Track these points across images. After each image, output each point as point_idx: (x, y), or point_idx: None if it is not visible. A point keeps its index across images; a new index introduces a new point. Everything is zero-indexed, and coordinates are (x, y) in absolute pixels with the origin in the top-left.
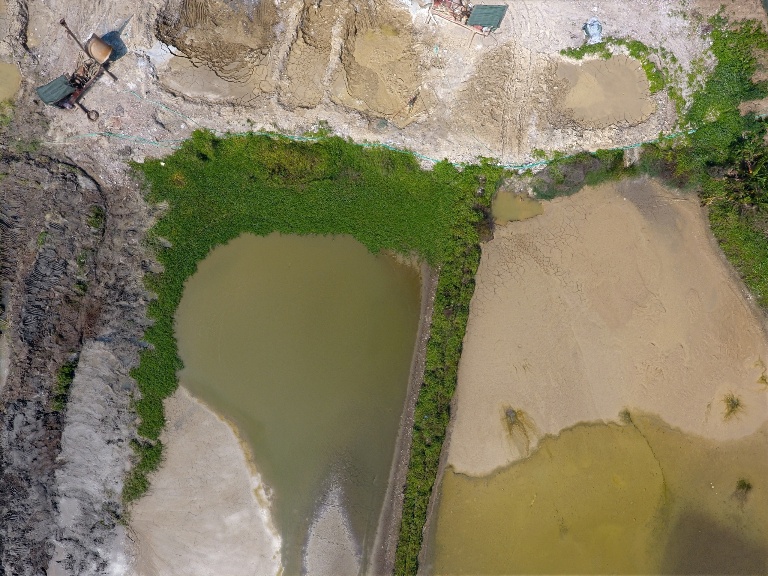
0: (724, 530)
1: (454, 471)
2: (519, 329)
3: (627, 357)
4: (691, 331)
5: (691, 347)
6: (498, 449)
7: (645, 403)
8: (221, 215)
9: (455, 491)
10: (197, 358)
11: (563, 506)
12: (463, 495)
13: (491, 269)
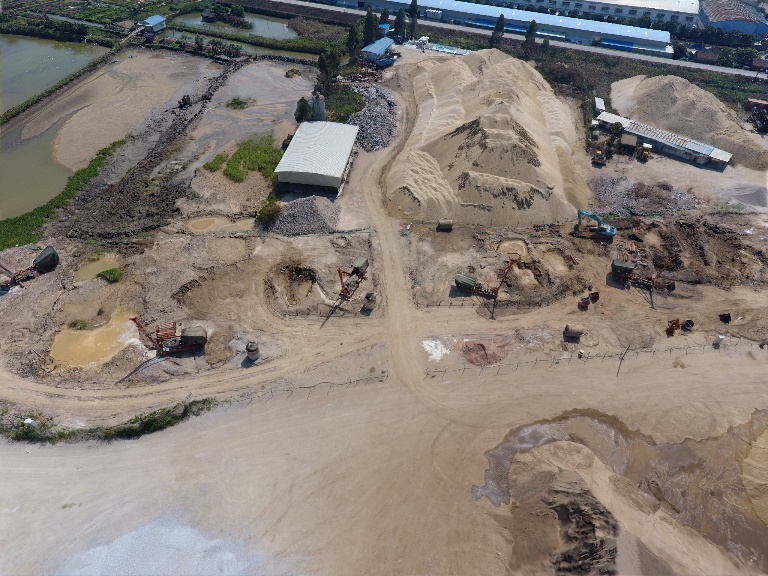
0: None
1: None
2: None
3: None
4: None
5: None
6: None
7: None
8: (0, 229)
9: None
10: (59, 180)
11: None
12: None
13: None
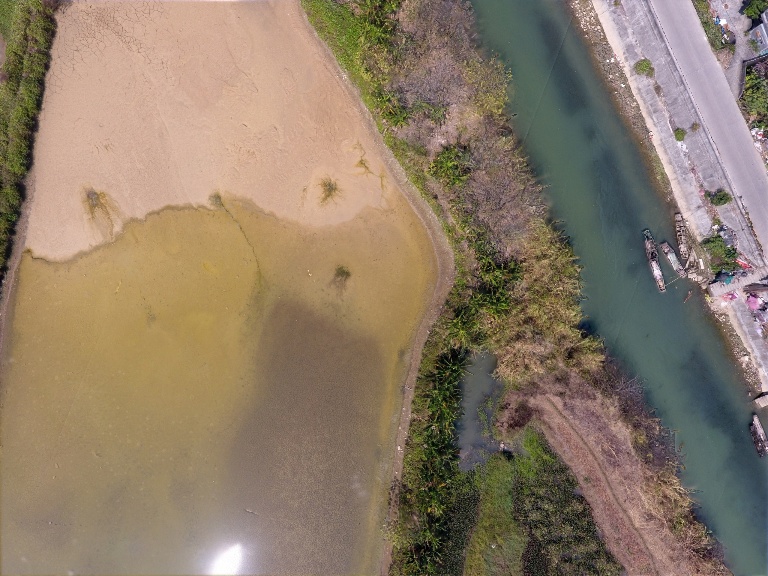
0: (322, 319)
1: (32, 256)
2: (100, 107)
3: (217, 138)
4: (285, 112)
5: (285, 129)
6: (80, 233)
7: (237, 187)
8: None
9: (34, 277)
10: None
11: (151, 293)
12: (42, 281)
13: (69, 44)
